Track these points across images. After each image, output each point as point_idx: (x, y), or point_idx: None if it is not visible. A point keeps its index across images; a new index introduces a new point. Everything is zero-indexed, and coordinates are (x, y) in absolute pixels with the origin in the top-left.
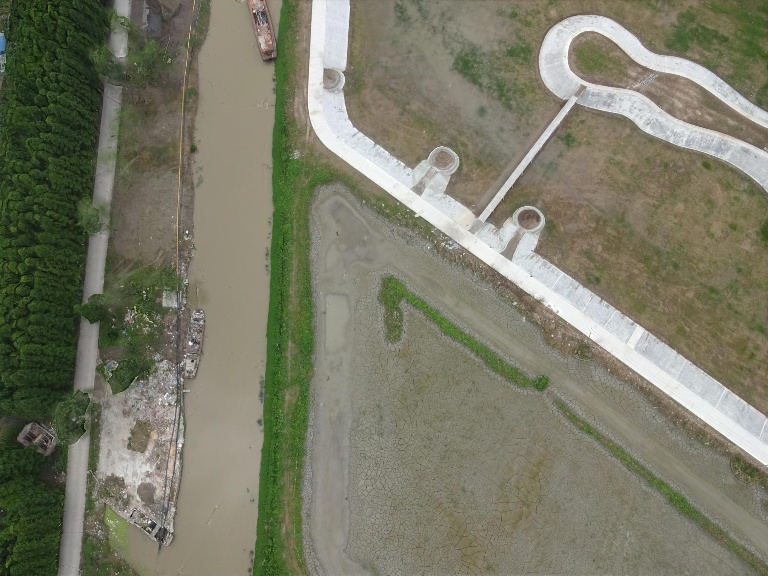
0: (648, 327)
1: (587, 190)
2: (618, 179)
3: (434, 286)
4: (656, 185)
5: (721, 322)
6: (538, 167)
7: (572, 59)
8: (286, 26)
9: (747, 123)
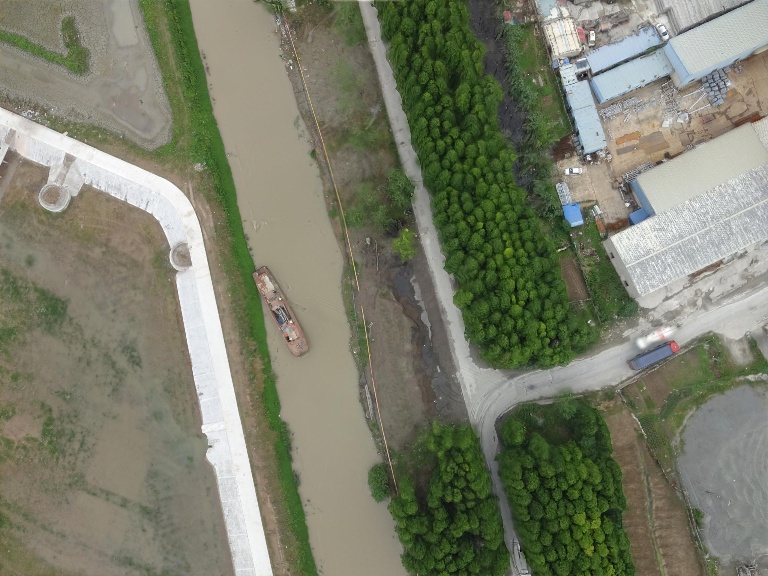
0: None
1: None
2: None
3: (42, 77)
4: None
5: None
6: None
7: None
8: (250, 311)
9: None
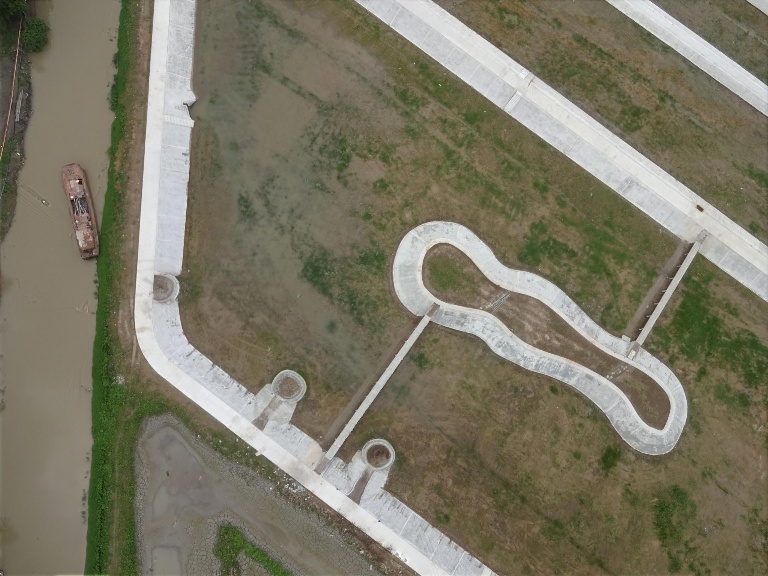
0: (495, 568)
1: (439, 417)
2: (470, 405)
3: (276, 533)
4: (506, 412)
5: (564, 558)
6: (390, 391)
7: (426, 274)
8: (110, 218)
9: (592, 349)
